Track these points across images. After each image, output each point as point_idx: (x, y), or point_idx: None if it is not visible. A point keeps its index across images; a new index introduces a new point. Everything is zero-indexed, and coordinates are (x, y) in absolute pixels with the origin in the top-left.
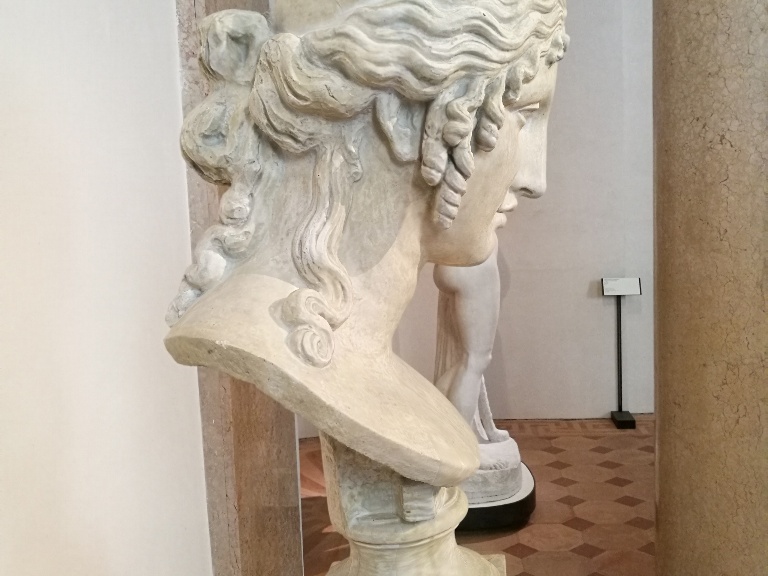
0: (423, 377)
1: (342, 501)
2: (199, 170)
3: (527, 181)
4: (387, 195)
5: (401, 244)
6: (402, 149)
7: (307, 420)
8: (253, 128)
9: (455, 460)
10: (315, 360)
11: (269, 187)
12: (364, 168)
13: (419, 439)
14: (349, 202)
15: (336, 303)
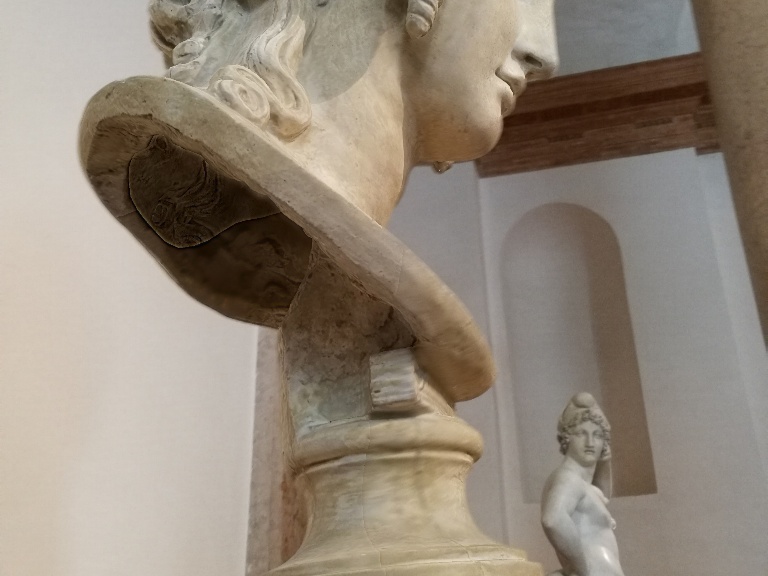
0: None
1: (289, 399)
2: (163, 41)
3: (532, 47)
4: (356, 20)
5: (375, 77)
6: None
7: (210, 148)
8: None
9: None
10: (234, 100)
11: (229, 33)
12: None
13: None
14: (311, 23)
15: (285, 105)
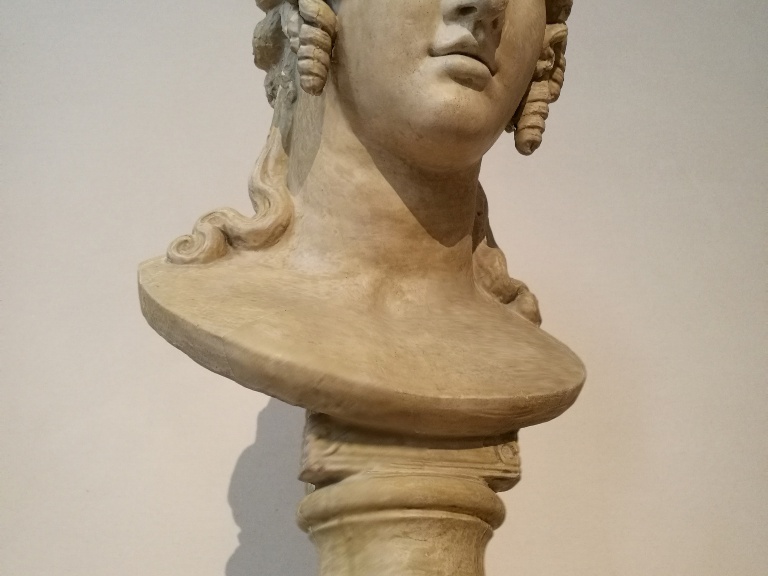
0: (541, 357)
1: None
2: None
3: None
4: None
5: (328, 141)
6: None
7: None
8: None
9: (263, 347)
10: (170, 256)
11: None
12: None
13: (221, 319)
14: (287, 123)
15: None
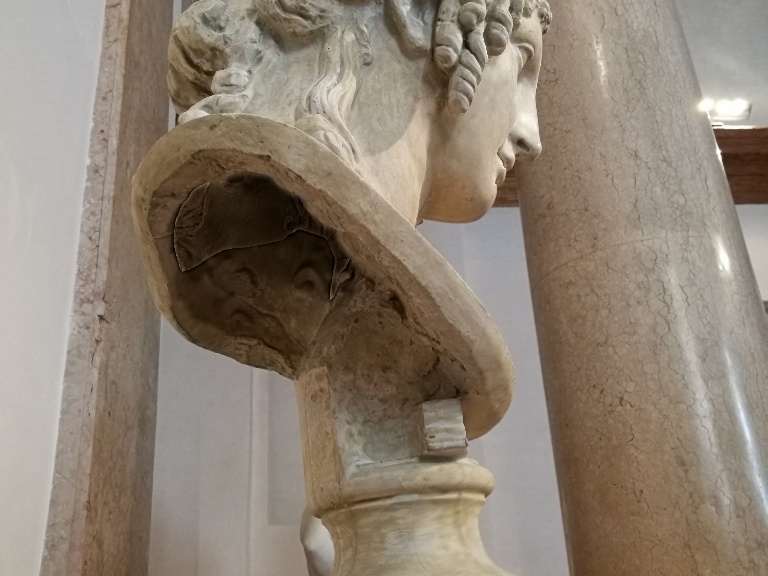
0: None
1: (338, 438)
2: (188, 62)
3: (524, 133)
4: (397, 85)
5: (410, 141)
6: (416, 34)
7: (334, 200)
8: (255, 23)
9: None
10: (340, 153)
11: (269, 70)
12: (374, 56)
13: None
14: (359, 80)
15: None
